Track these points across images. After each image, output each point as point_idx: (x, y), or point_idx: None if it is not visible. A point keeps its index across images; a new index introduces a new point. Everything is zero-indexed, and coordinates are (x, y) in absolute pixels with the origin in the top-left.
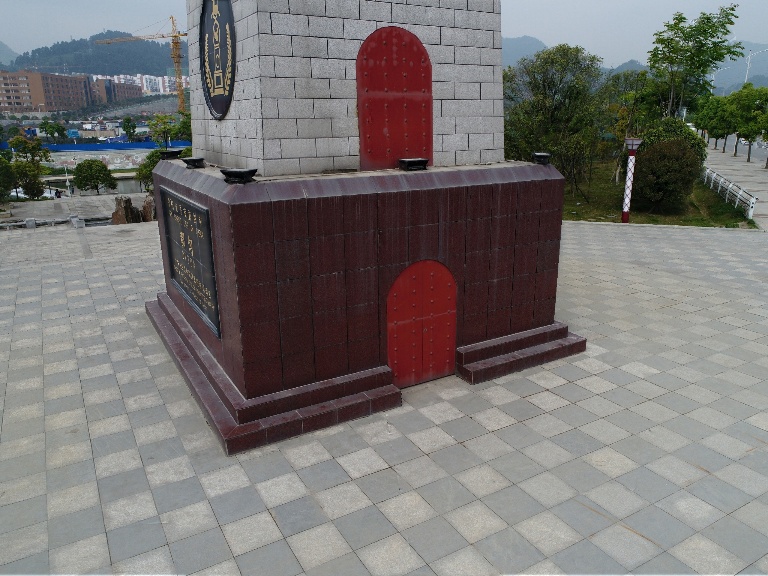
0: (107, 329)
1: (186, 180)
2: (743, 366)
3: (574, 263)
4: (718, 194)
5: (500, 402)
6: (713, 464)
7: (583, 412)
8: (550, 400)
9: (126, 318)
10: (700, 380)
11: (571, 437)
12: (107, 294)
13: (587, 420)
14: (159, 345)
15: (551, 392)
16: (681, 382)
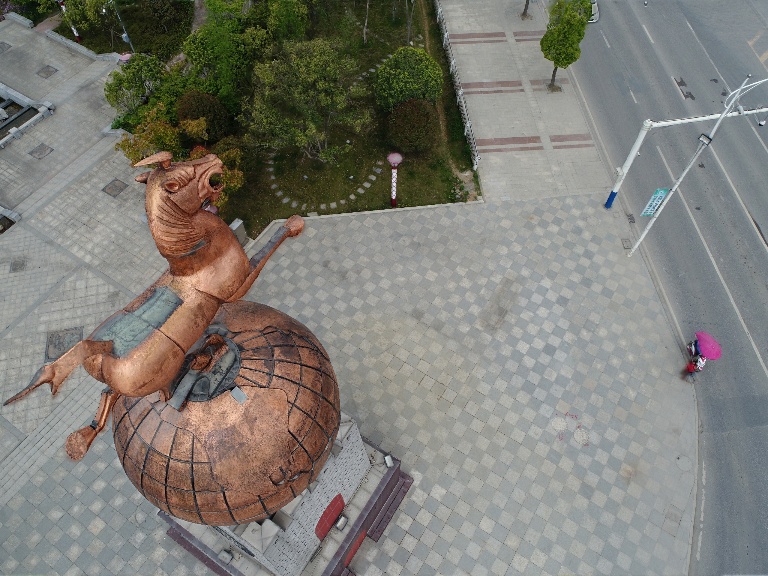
0: (166, 568)
1: (230, 570)
2: (477, 470)
3: (380, 330)
4: (450, 77)
5: (392, 554)
6: (470, 567)
7: (424, 547)
8: (410, 542)
9: (164, 549)
10: (462, 494)
11: (424, 571)
12: (119, 520)
13: (427, 554)
14: (211, 572)
15: (409, 534)
16: (455, 499)
